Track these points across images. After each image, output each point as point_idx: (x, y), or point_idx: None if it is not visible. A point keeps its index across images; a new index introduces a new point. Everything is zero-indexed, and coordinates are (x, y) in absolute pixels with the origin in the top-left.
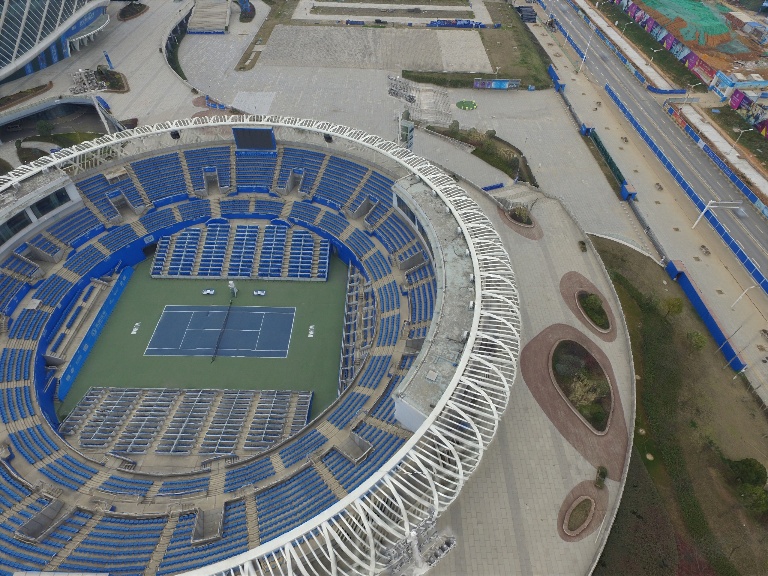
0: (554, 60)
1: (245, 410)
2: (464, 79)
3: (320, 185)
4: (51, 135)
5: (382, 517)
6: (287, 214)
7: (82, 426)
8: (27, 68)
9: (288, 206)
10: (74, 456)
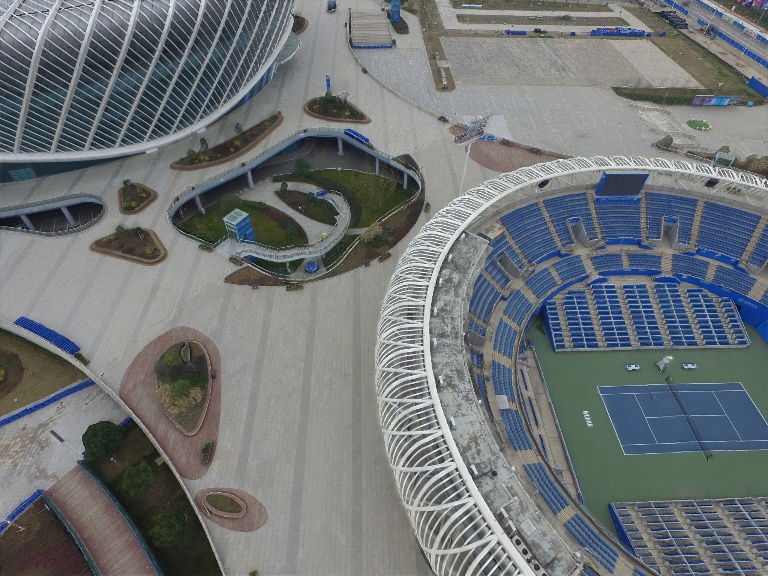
0: (742, 71)
1: None
2: (678, 95)
3: (700, 235)
4: None
5: None
6: (668, 269)
7: None
8: (246, 96)
9: (666, 259)
10: None
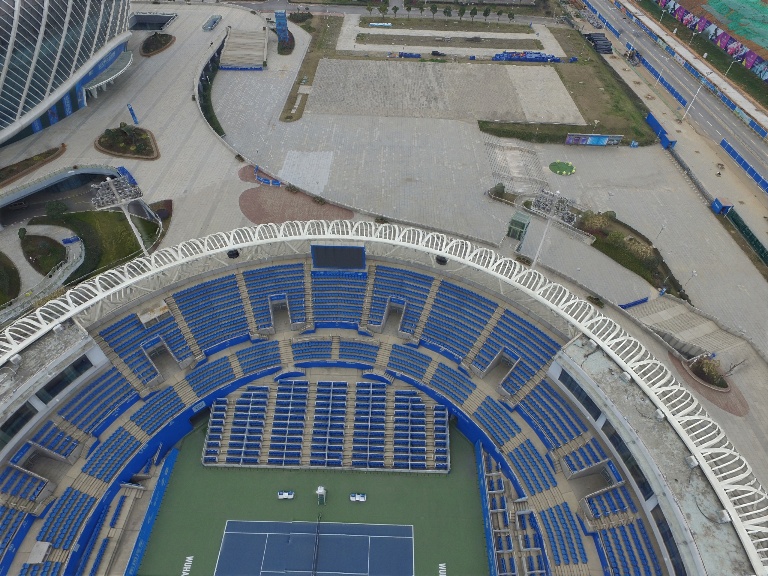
0: (648, 104)
1: None
2: (553, 132)
3: (428, 322)
4: (63, 216)
5: None
6: (384, 363)
7: None
8: (35, 125)
9: (385, 351)
10: None
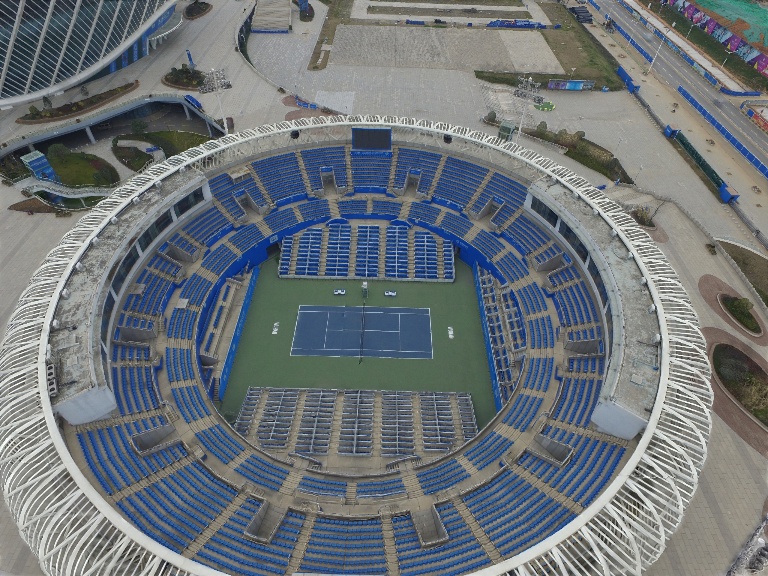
0: (620, 61)
1: (410, 411)
2: (537, 80)
3: (438, 186)
4: (142, 134)
5: (638, 522)
6: (406, 215)
7: (253, 426)
8: (111, 66)
9: (406, 207)
10: (260, 456)
